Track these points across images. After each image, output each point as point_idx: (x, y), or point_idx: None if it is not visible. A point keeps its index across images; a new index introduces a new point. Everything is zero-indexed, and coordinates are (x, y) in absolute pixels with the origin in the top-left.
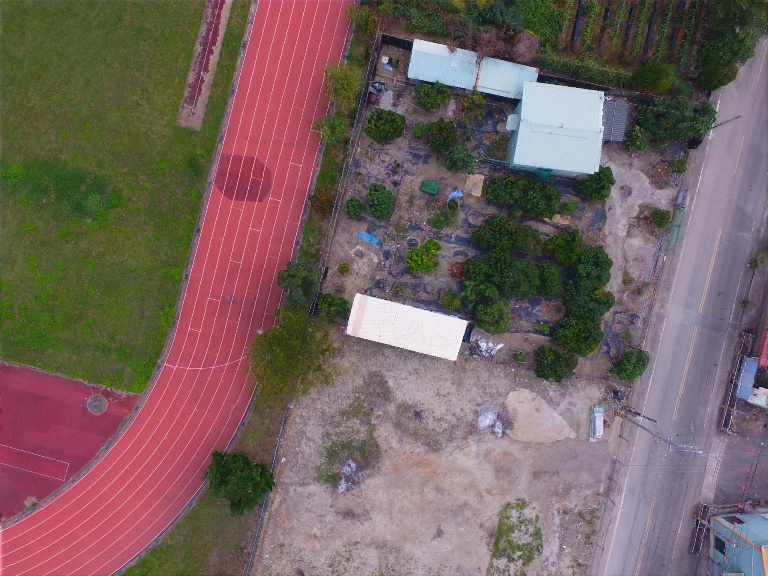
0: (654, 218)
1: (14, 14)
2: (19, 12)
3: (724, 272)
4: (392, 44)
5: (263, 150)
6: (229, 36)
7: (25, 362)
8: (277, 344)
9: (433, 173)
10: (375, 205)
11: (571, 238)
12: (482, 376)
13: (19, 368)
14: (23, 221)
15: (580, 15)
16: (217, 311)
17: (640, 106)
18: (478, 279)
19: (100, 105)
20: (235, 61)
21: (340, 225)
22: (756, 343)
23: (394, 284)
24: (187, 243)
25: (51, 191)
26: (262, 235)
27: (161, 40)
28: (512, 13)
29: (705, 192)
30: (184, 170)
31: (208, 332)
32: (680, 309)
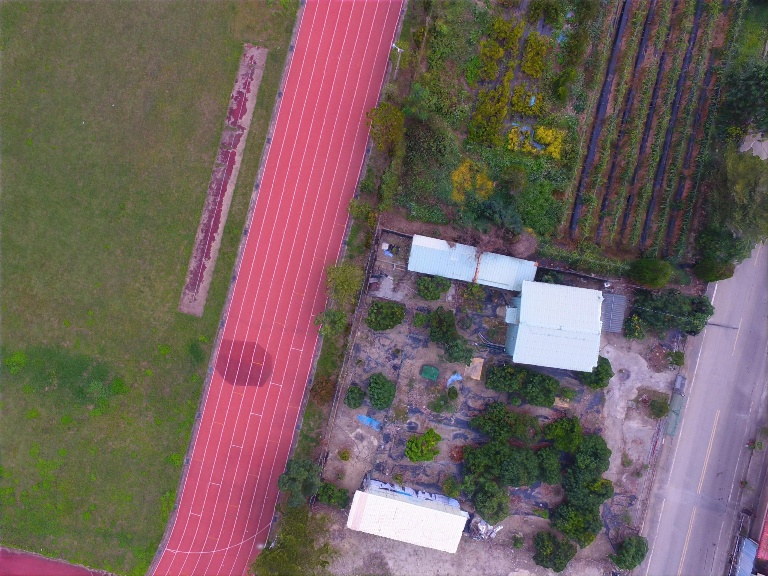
0: (652, 409)
1: (18, 204)
2: (23, 202)
3: (722, 453)
4: (392, 233)
5: (264, 335)
6: (230, 223)
7: (27, 548)
8: (277, 566)
9: (433, 357)
10: (375, 399)
11: (570, 428)
12: (482, 557)
13: (21, 554)
14: (25, 408)
15: (578, 204)
16: (218, 495)
17: (638, 296)
18: (477, 472)
19: (102, 293)
20: (236, 248)
21: (340, 409)
22: (754, 523)
23: (394, 467)
24: (188, 428)
25: (53, 379)
26: (263, 420)
27: (163, 228)
28: (511, 213)
29: (703, 374)
30: (185, 356)
31: (209, 516)
32: (679, 490)
